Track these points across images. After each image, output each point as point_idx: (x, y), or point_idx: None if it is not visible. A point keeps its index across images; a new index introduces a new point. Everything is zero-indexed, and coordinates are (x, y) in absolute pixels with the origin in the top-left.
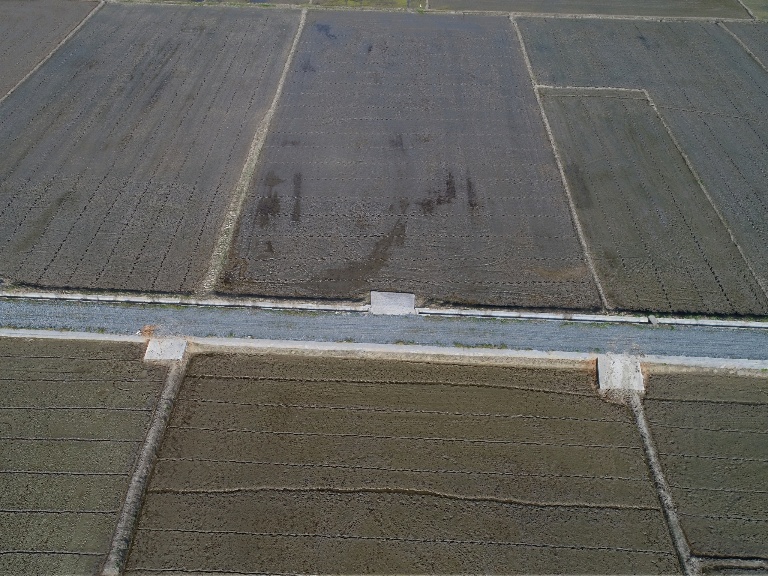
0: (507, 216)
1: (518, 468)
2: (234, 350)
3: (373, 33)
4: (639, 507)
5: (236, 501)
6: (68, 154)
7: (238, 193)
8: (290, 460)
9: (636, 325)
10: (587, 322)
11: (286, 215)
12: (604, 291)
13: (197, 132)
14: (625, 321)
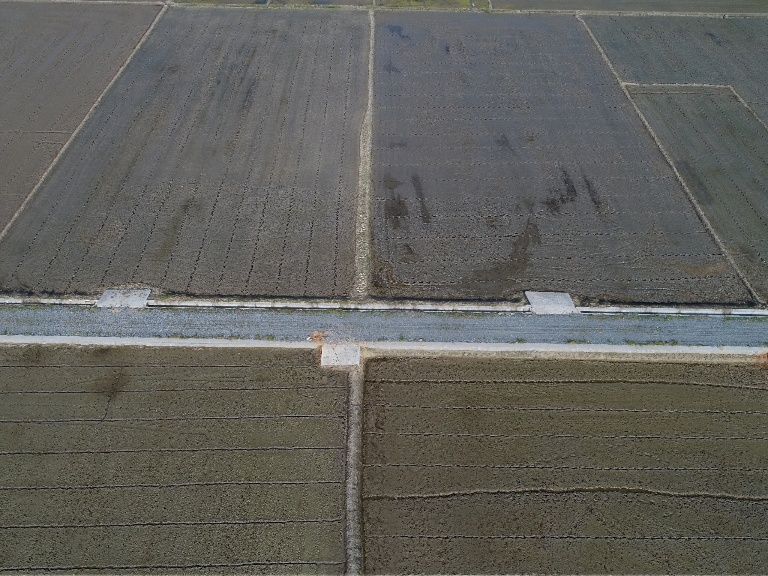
0: (634, 213)
1: (721, 463)
2: (406, 354)
3: (446, 33)
4: None
5: (454, 505)
6: (178, 160)
7: (362, 196)
8: (495, 462)
9: None
10: (748, 316)
11: (416, 217)
12: (751, 285)
13: (301, 135)
14: None
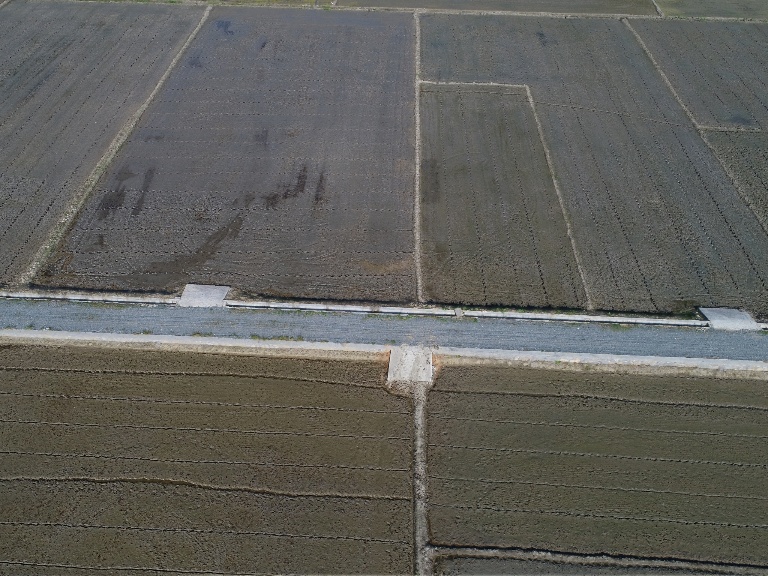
0: (349, 210)
1: (281, 458)
2: (32, 342)
3: (272, 29)
4: (391, 497)
5: None
6: None
7: (85, 187)
8: (55, 450)
9: (440, 317)
10: (392, 314)
11: (127, 209)
12: (423, 284)
13: (64, 127)
14: (432, 314)
